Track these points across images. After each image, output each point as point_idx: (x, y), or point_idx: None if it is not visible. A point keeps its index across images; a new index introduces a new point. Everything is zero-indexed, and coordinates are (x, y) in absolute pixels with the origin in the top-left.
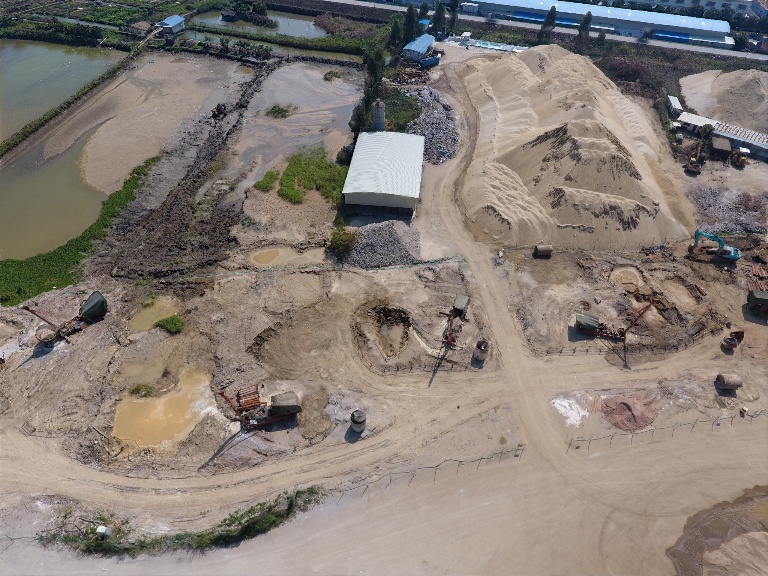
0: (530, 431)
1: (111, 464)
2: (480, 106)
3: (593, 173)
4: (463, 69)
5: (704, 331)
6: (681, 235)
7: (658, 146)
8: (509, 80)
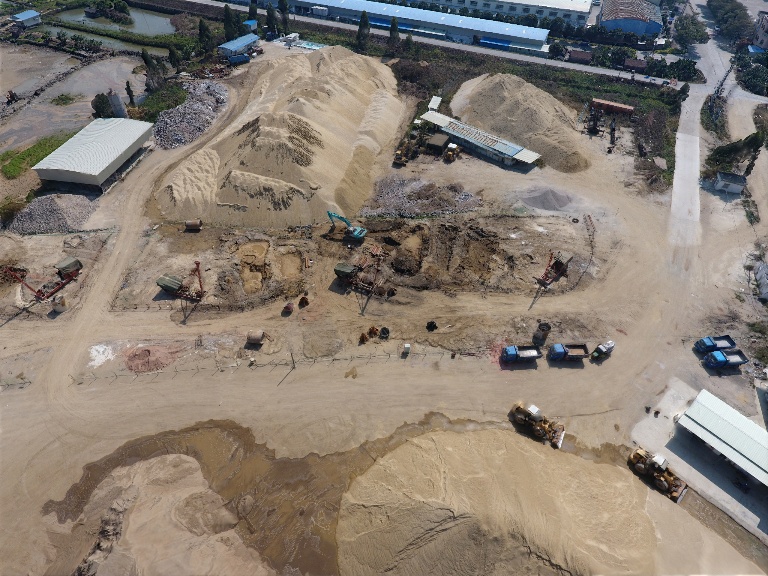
0: (50, 369)
1: None
2: (252, 100)
3: (262, 159)
4: (264, 67)
5: (280, 297)
6: None
7: (389, 140)
8: (281, 77)
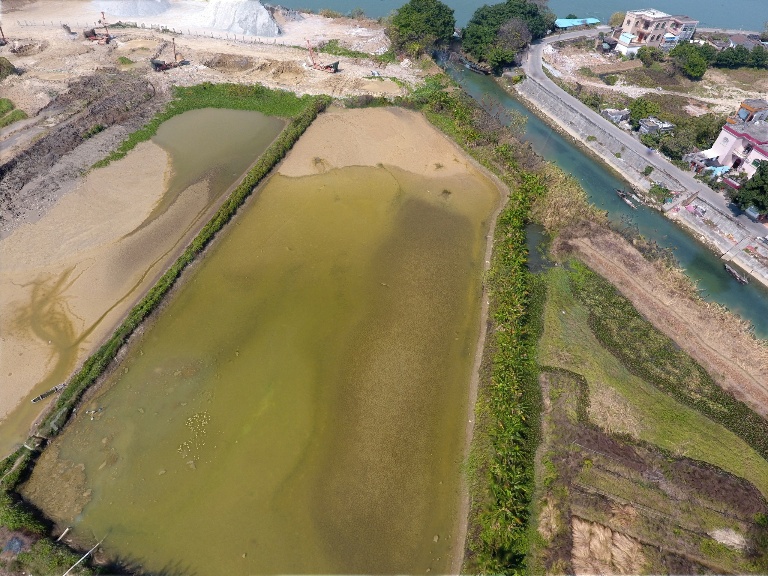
0: None
1: None
2: None
3: None
4: None
5: None
6: None
7: None
8: None
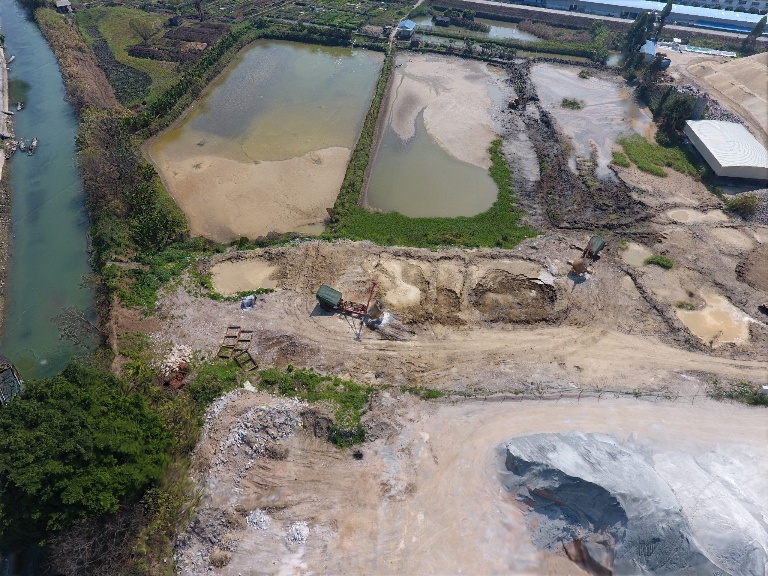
0: None
1: (713, 352)
2: (741, 101)
3: None
4: (699, 70)
5: None
6: None
7: None
8: (765, 79)
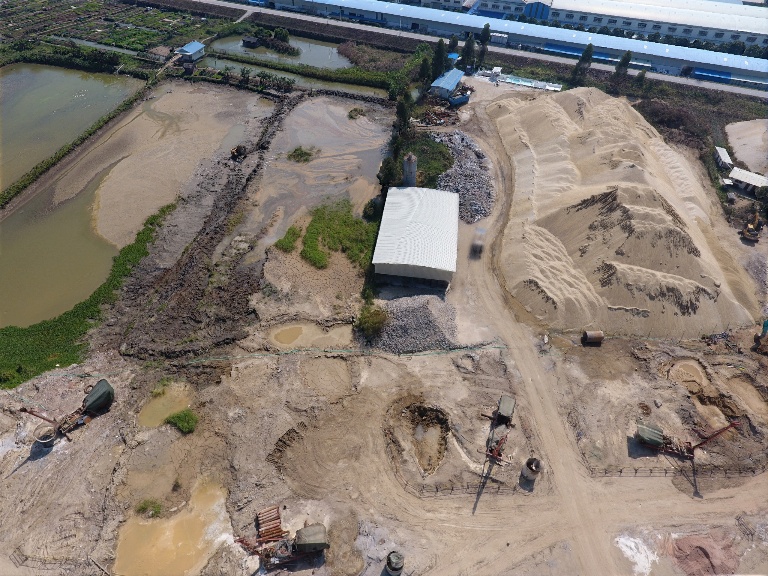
0: None
1: None
2: (514, 154)
3: (647, 248)
4: (495, 110)
5: None
6: (745, 320)
7: (709, 207)
8: (546, 127)
